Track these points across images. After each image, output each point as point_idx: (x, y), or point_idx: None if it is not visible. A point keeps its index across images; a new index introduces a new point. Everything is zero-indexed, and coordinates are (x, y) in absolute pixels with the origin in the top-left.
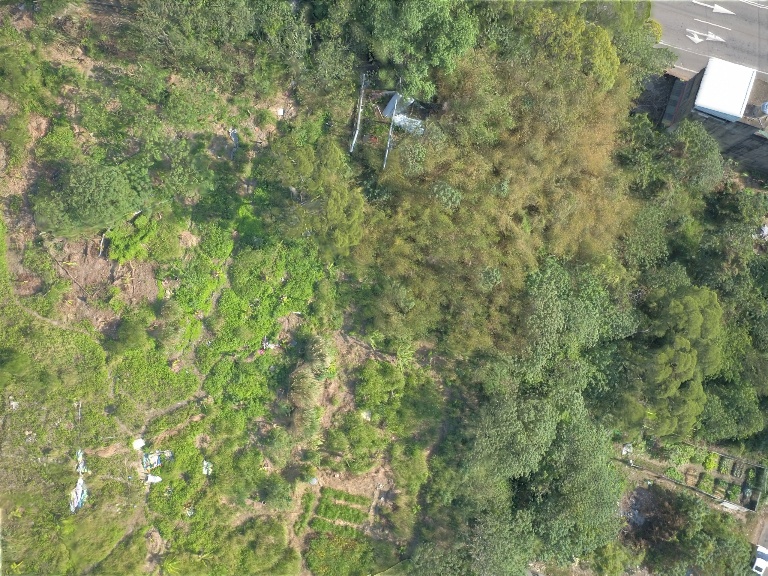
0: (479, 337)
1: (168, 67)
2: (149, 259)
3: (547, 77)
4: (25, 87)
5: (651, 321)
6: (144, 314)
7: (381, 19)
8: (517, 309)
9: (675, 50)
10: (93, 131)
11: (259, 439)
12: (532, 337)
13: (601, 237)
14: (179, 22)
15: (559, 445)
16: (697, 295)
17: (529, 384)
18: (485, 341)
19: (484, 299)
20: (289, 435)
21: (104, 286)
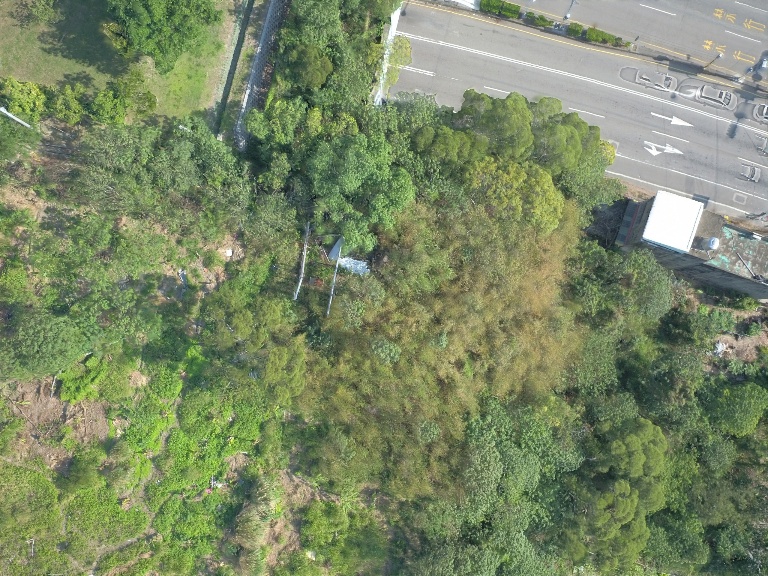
0: (419, 485)
1: (119, 210)
2: (100, 399)
3: (486, 232)
4: None
5: (601, 444)
6: (95, 453)
7: (321, 177)
8: (456, 460)
9: (633, 162)
10: (46, 272)
11: None
12: (470, 487)
13: (547, 371)
14: (124, 179)
15: None
16: (641, 431)
17: (471, 524)
18: (425, 489)
19: (424, 449)
20: (236, 573)
21: (56, 426)
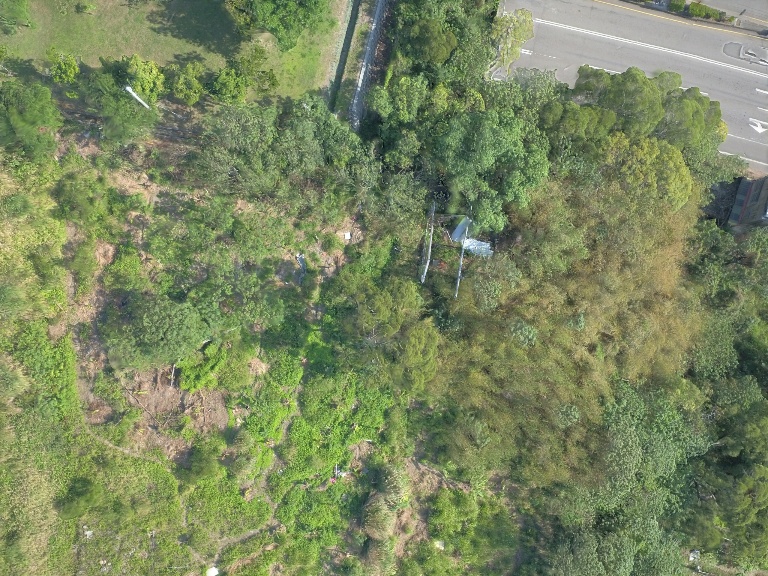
0: (555, 471)
1: (235, 193)
2: (219, 388)
3: (624, 209)
4: (93, 217)
5: (720, 429)
6: (215, 443)
7: (455, 155)
8: (595, 444)
9: (738, 140)
10: (161, 258)
11: (332, 568)
12: (610, 473)
13: (672, 353)
14: (250, 160)
15: (636, 575)
16: None
17: (603, 511)
18: (561, 475)
19: (560, 433)
20: (362, 564)
21: (175, 416)
